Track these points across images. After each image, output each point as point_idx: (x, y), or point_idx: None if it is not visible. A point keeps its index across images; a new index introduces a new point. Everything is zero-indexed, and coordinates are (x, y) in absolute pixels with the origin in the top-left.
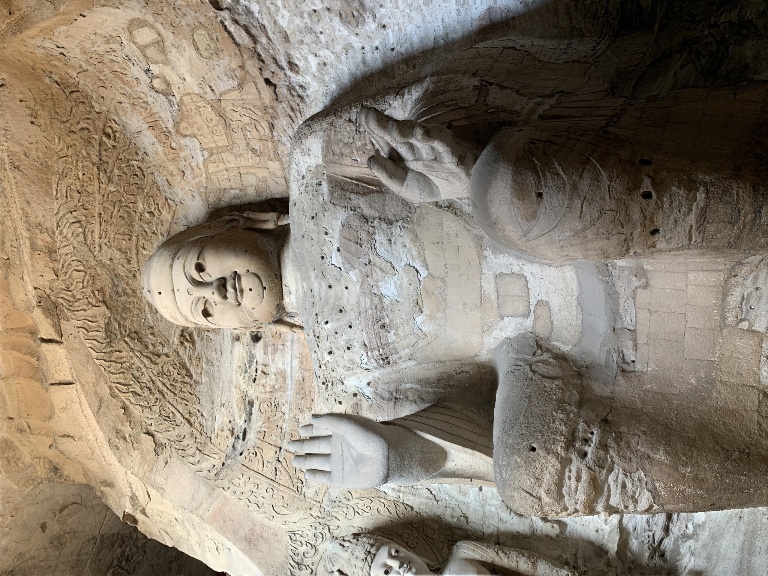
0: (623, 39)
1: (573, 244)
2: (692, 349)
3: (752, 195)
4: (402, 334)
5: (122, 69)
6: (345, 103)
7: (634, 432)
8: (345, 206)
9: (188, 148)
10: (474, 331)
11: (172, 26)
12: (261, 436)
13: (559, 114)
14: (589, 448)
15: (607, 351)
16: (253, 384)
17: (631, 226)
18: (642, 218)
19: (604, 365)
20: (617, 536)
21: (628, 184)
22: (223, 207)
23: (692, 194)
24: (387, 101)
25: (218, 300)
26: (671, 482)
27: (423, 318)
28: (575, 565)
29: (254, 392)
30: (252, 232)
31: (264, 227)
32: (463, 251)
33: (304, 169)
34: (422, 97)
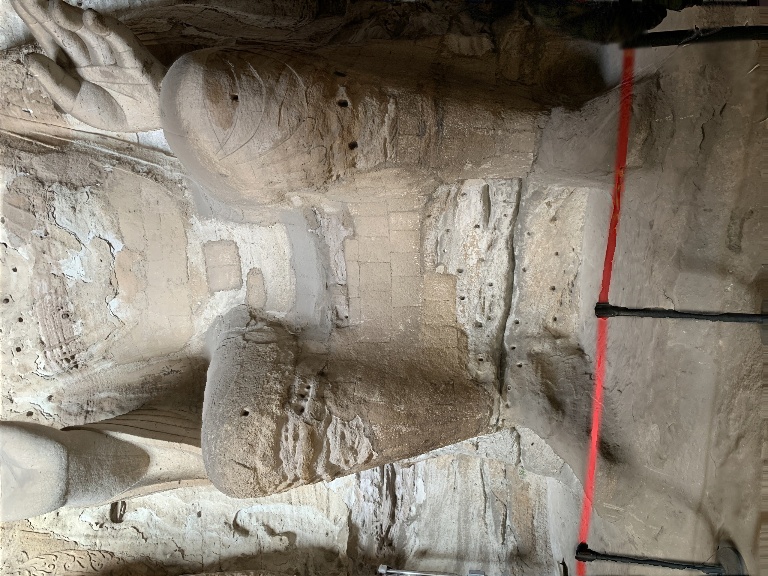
0: (322, 19)
1: (274, 161)
2: (399, 297)
3: (434, 108)
4: (92, 323)
5: None
6: None
7: (350, 380)
8: (12, 166)
9: None
10: (181, 313)
11: None
12: None
13: (257, 41)
14: (306, 402)
15: (321, 310)
16: None
17: (330, 137)
18: (340, 128)
19: (319, 325)
20: (347, 534)
21: (324, 91)
22: None
23: (383, 105)
24: None
25: None
26: (387, 423)
27: (118, 301)
28: (306, 575)
29: None
30: None
31: None
32: (165, 219)
33: None
34: None
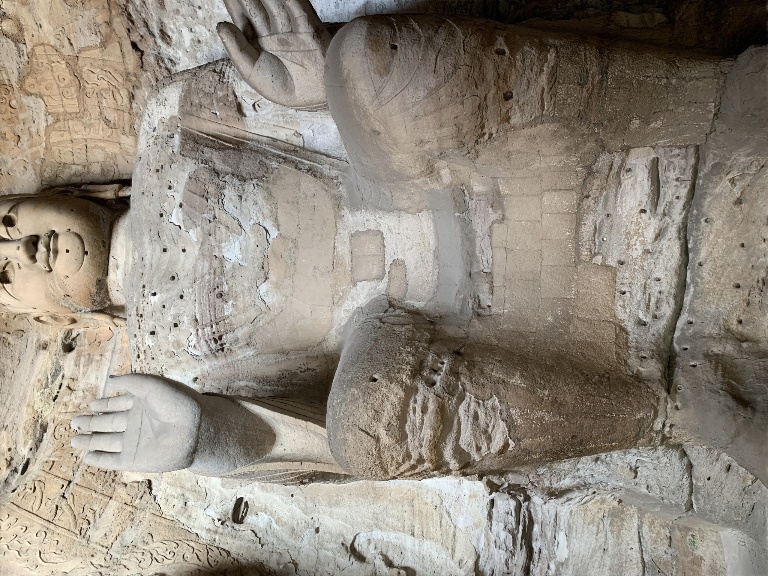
0: None
1: (427, 113)
2: (548, 288)
3: (598, 56)
4: (241, 305)
5: None
6: None
7: (488, 361)
8: (196, 158)
9: (30, 109)
10: (323, 303)
11: None
12: (47, 467)
13: None
14: (438, 376)
15: (463, 299)
16: (52, 403)
17: (485, 86)
18: (496, 76)
19: (459, 313)
20: None
21: (482, 40)
22: (59, 185)
23: (543, 54)
24: None
25: (23, 260)
26: (528, 407)
27: (267, 286)
28: None
29: (51, 412)
30: (86, 200)
31: (101, 195)
32: (319, 211)
33: (157, 121)
34: None
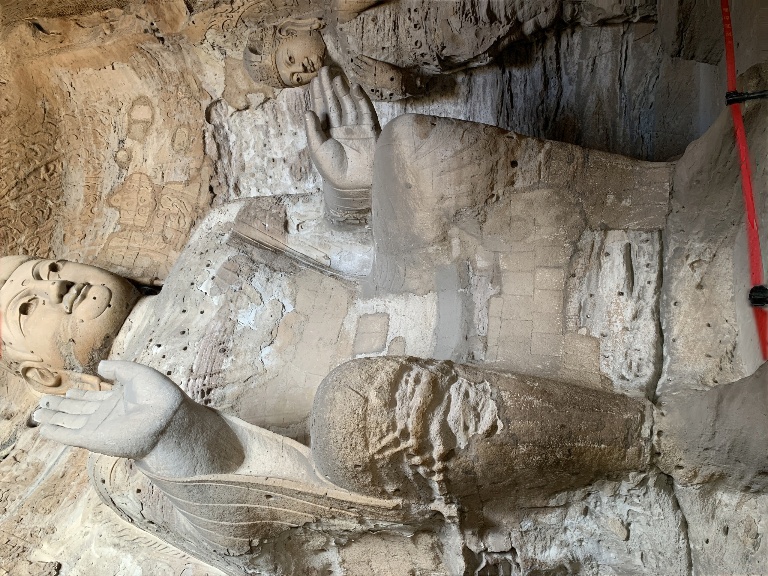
0: None
1: (451, 169)
2: (538, 348)
3: (581, 149)
4: (240, 362)
5: (103, 131)
6: None
7: None
8: (239, 248)
9: (106, 217)
10: (320, 372)
11: (167, 115)
12: None
13: None
14: None
15: (457, 355)
16: None
17: (497, 155)
18: (506, 149)
19: None
20: None
21: (497, 130)
22: None
23: (541, 144)
24: None
25: (51, 296)
26: (518, 392)
27: (271, 349)
28: None
29: None
30: None
31: (138, 279)
32: (334, 298)
33: (214, 223)
34: None
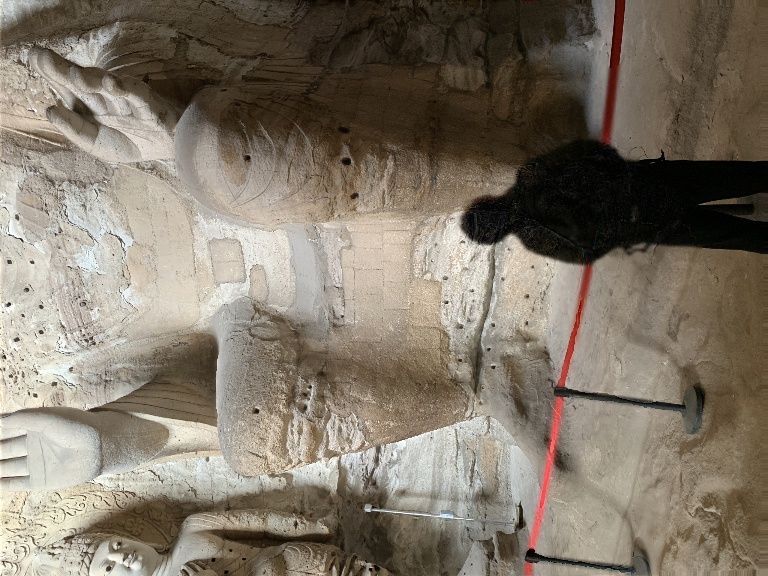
0: (319, 9)
1: (283, 208)
2: (389, 300)
3: (429, 164)
4: (108, 310)
5: None
6: (11, 40)
7: (346, 380)
8: (22, 165)
9: None
10: (189, 300)
11: None
12: None
13: (262, 77)
14: (308, 401)
15: (319, 309)
16: None
17: (334, 190)
18: (343, 183)
19: (318, 322)
20: (337, 476)
21: (329, 150)
22: None
23: (383, 161)
24: (68, 44)
25: None
26: (378, 419)
27: (131, 291)
28: (302, 511)
29: None
30: None
31: None
32: (172, 217)
33: None
34: (111, 43)
